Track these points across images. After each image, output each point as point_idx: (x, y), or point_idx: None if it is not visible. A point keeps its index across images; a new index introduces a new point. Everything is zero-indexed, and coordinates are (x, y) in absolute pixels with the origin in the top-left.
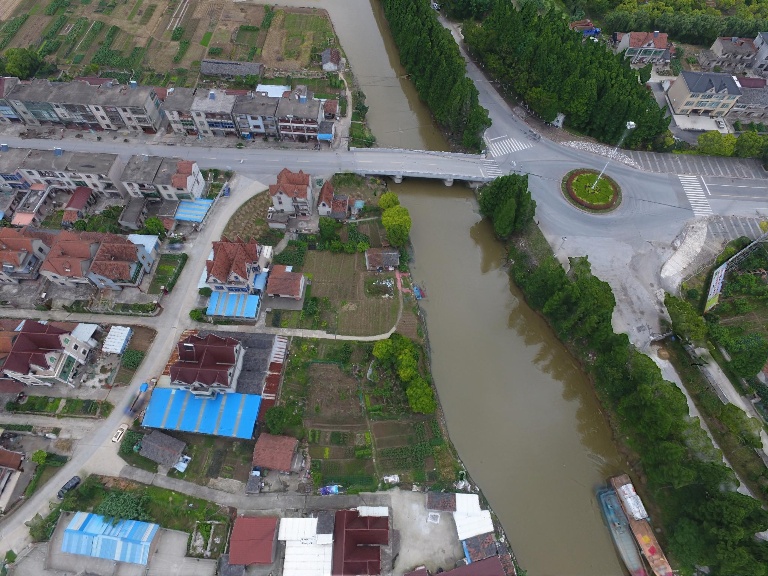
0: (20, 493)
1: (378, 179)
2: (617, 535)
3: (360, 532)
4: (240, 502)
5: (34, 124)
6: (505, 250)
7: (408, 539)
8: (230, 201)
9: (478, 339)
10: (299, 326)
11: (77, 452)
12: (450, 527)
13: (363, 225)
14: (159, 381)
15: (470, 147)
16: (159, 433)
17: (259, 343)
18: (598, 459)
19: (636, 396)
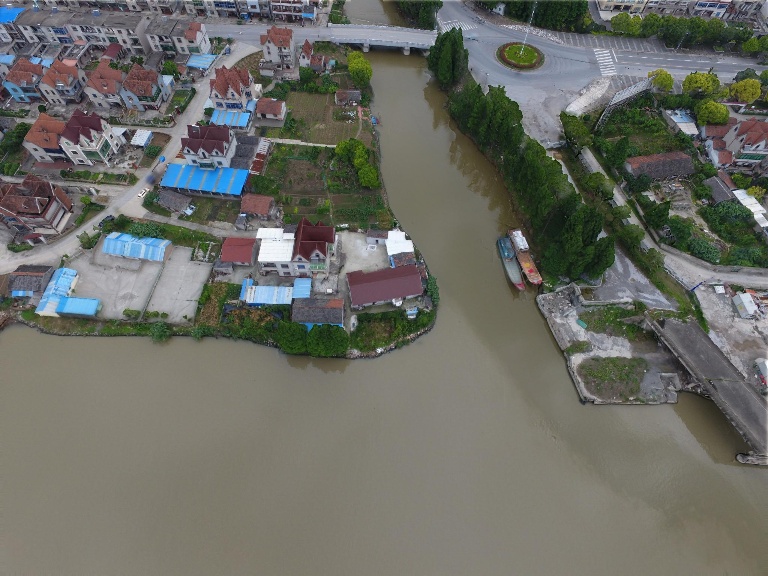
0: (71, 224)
1: (350, 49)
2: (506, 262)
3: (313, 229)
4: (231, 235)
5: (75, 6)
6: (447, 97)
7: (352, 258)
8: (230, 58)
9: (422, 161)
10: (280, 137)
11: (112, 204)
12: (383, 253)
13: (335, 77)
14: (173, 161)
15: (426, 27)
16: (172, 192)
17: (248, 140)
18: (500, 222)
19: (525, 165)
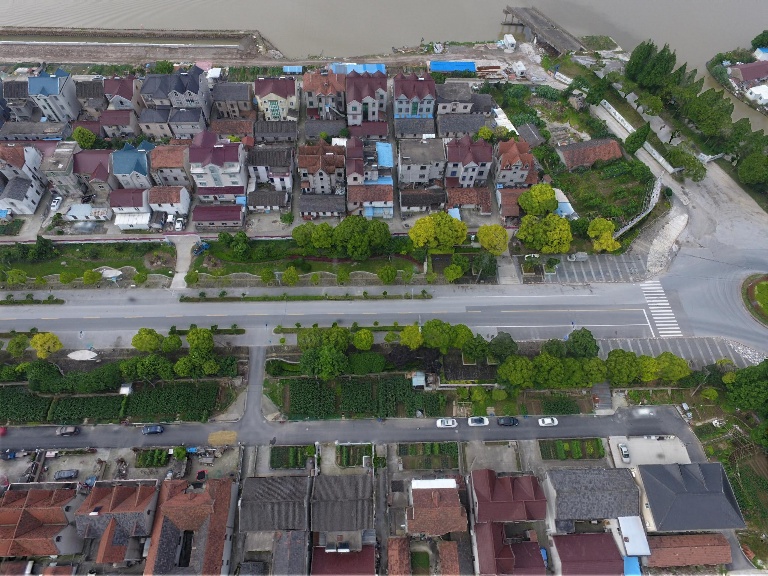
0: None
1: None
2: None
3: None
4: None
5: None
6: None
7: None
8: None
9: None
10: None
11: None
12: None
13: None
14: None
15: None
16: None
17: None
18: None
19: None
